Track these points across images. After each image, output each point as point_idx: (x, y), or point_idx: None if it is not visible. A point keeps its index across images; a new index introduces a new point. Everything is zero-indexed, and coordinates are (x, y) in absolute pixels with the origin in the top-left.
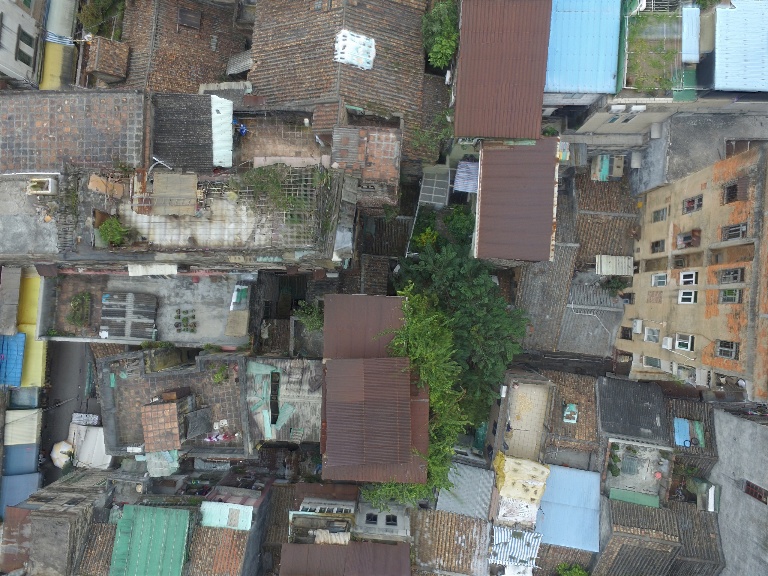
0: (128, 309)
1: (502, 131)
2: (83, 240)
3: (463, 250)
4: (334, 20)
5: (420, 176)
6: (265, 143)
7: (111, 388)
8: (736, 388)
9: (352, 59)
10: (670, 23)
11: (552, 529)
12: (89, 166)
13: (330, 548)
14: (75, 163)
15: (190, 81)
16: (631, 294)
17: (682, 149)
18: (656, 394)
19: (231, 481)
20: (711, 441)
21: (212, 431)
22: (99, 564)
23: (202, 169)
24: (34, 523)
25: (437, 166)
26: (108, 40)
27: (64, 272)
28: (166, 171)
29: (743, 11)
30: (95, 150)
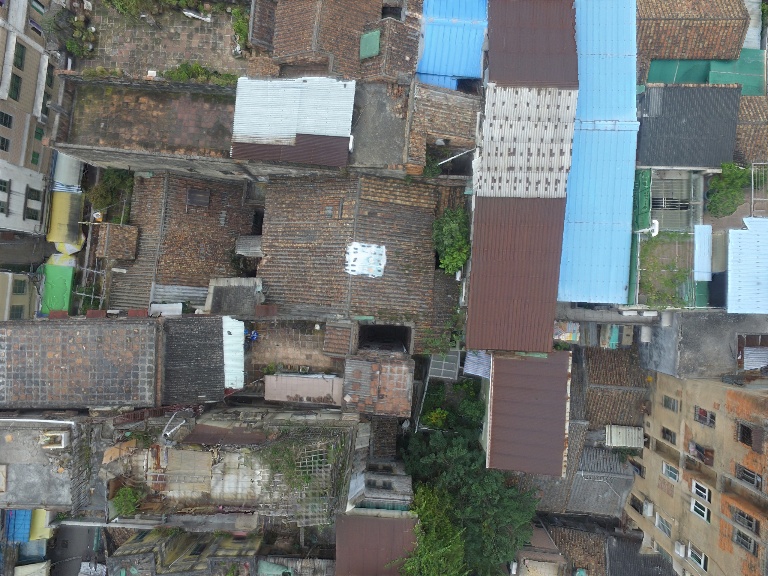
0: None
1: (514, 345)
2: (96, 491)
3: (473, 433)
4: (345, 229)
5: None
6: (276, 346)
7: None
8: None
9: (363, 269)
10: (682, 240)
11: None
12: (101, 398)
13: None
14: (87, 395)
15: (199, 259)
16: (641, 467)
17: (693, 343)
18: None
19: None
20: None
21: None
22: None
23: (214, 392)
24: None
25: None
26: (117, 225)
27: None
28: (179, 421)
29: (756, 232)
30: (107, 381)
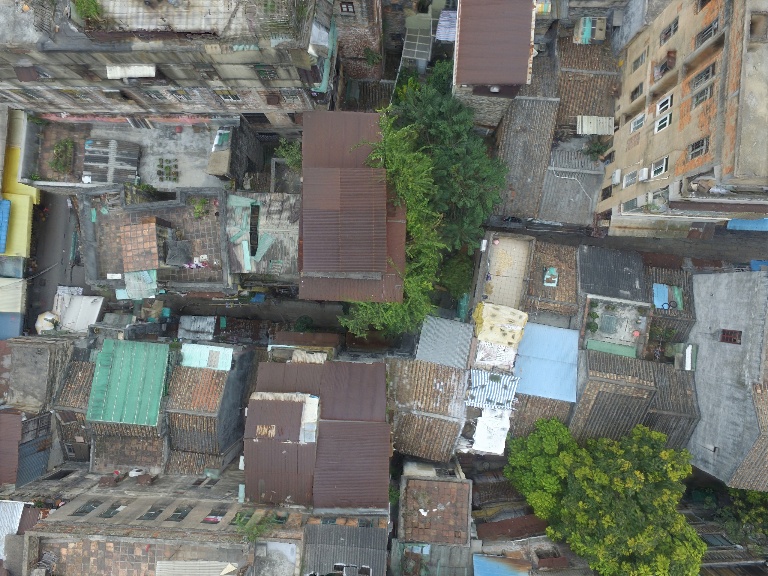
0: (111, 156)
1: None
2: (61, 31)
3: None
4: None
5: (404, 35)
6: None
7: (92, 223)
8: (707, 194)
9: None
10: None
11: (530, 381)
12: None
13: (306, 366)
14: None
15: None
16: (611, 153)
17: None
18: (636, 261)
19: (213, 341)
20: (689, 305)
21: None
22: (79, 397)
23: None
24: (14, 353)
25: (419, 15)
26: None
27: (47, 118)
28: None
29: None
30: None
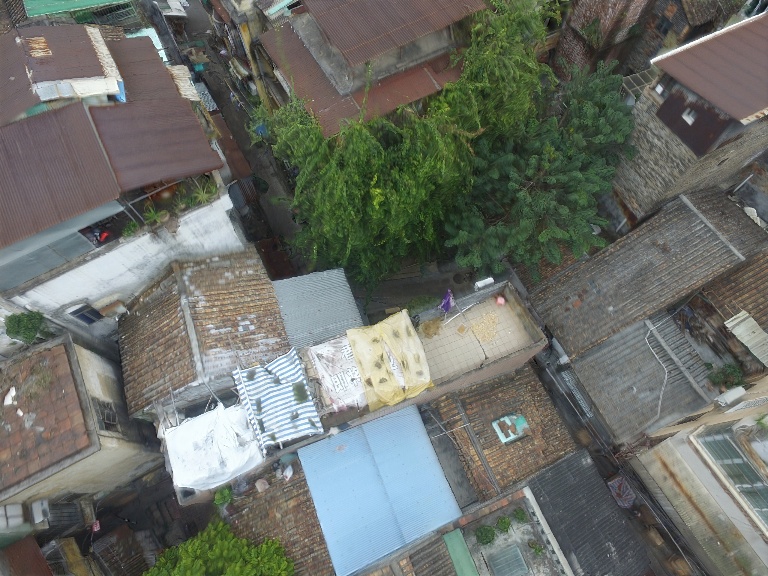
0: None
1: None
2: None
3: None
4: None
5: None
6: None
7: None
8: None
9: None
10: None
11: (332, 472)
12: None
13: (168, 80)
14: None
15: None
16: None
17: None
18: (635, 557)
19: None
20: None
21: None
22: None
23: None
24: None
25: None
26: None
27: None
28: None
29: None
30: None
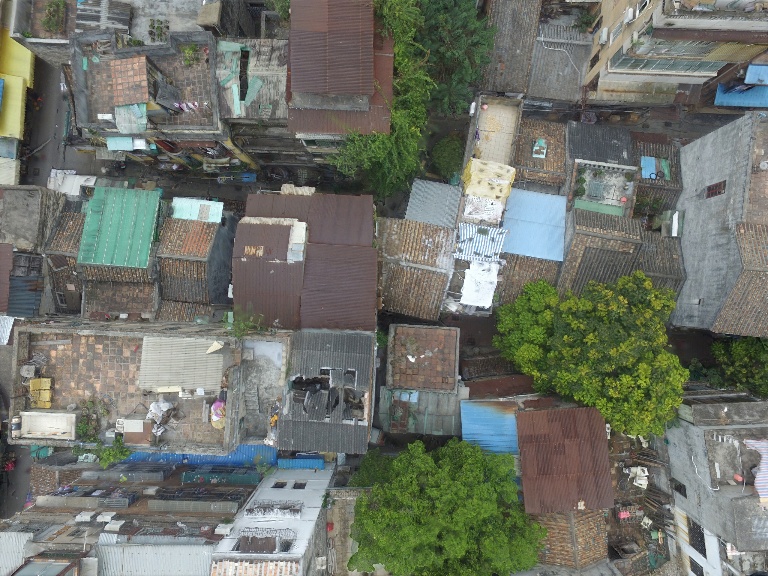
0: (103, 14)
1: None
2: None
3: None
4: None
5: None
6: None
7: (83, 71)
8: (689, 11)
9: None
10: None
11: (518, 242)
12: None
13: (295, 198)
14: None
15: None
16: (599, 19)
17: None
18: (624, 135)
19: None
20: (676, 175)
21: (183, 114)
22: (70, 243)
23: None
24: (6, 197)
25: None
26: None
27: None
28: None
29: None
30: None
